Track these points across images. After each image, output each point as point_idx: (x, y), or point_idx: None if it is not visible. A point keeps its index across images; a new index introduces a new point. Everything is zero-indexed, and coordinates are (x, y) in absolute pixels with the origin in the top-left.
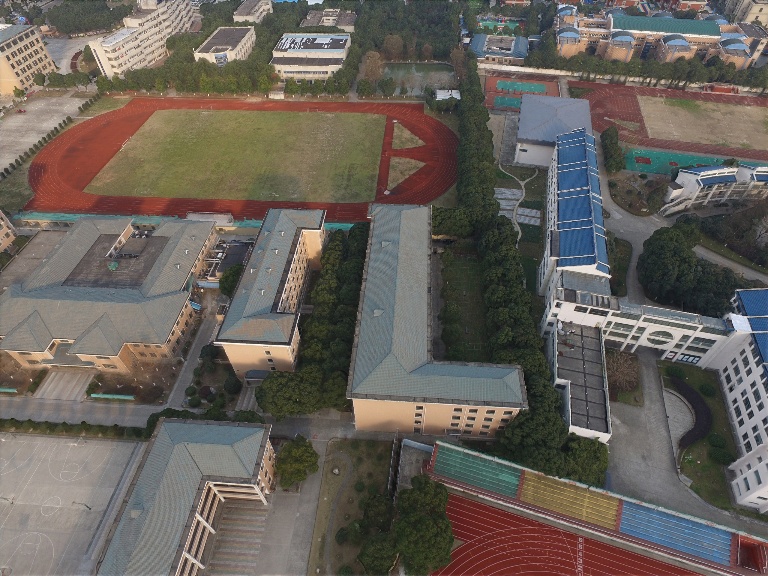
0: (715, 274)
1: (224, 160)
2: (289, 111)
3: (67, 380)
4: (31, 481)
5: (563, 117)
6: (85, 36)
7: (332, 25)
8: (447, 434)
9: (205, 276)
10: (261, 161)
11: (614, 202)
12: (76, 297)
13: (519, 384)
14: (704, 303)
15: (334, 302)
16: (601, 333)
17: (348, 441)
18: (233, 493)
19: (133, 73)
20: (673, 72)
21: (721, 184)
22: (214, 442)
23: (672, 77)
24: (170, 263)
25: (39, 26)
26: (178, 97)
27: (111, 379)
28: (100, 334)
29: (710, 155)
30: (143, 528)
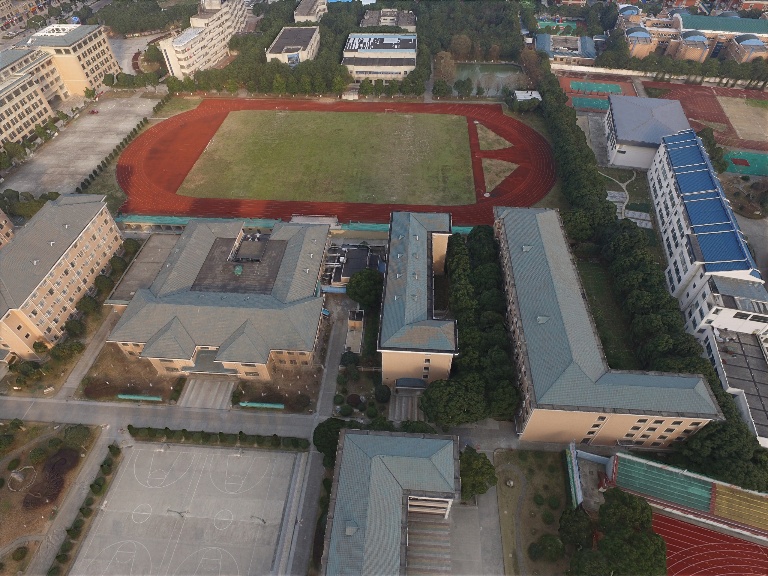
0: None
1: (312, 162)
2: (366, 112)
3: (208, 388)
4: (196, 493)
5: (660, 118)
6: (140, 36)
7: (391, 25)
8: (616, 445)
9: (326, 281)
10: (350, 163)
11: None
12: (214, 303)
13: (708, 394)
14: None
15: (476, 308)
16: (760, 340)
17: (514, 452)
18: (418, 507)
19: (203, 73)
20: (752, 72)
21: None
22: (410, 455)
23: (751, 77)
24: (299, 268)
25: None
26: (249, 98)
27: (259, 387)
28: (247, 341)
29: None
30: (365, 546)
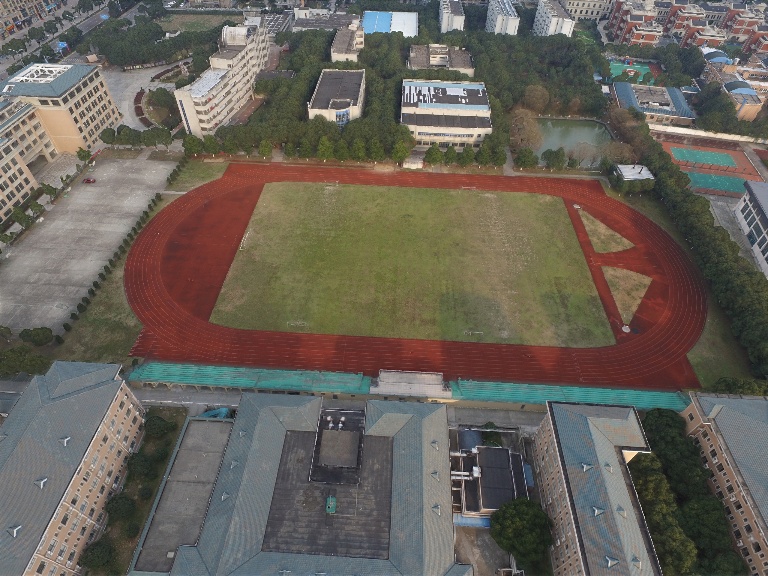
0: None
1: (385, 268)
2: (436, 188)
3: None
4: None
5: None
6: (141, 68)
7: None
8: None
9: None
10: (435, 271)
11: None
12: None
13: None
14: None
15: None
16: None
17: None
18: None
19: (228, 130)
20: None
21: None
22: None
23: None
24: (427, 507)
25: (84, 54)
26: (287, 163)
27: None
28: None
29: None
30: None
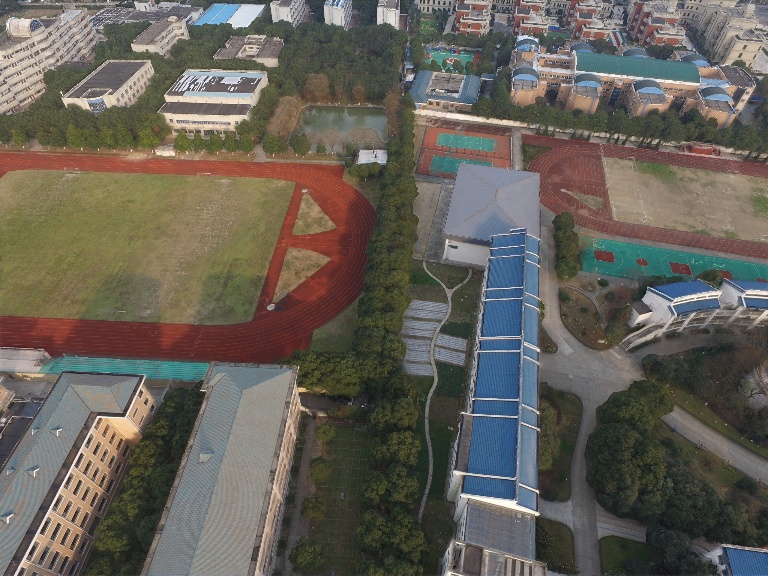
0: (692, 495)
1: (70, 251)
2: (176, 174)
3: None
4: None
5: (504, 202)
6: None
7: None
8: None
9: None
10: (118, 253)
11: (564, 326)
12: None
13: None
14: (675, 556)
15: (123, 550)
16: None
17: None
18: None
19: None
20: (644, 129)
21: (700, 310)
22: None
23: (643, 135)
24: None
25: None
26: (43, 151)
27: None
28: None
29: (687, 248)
30: None
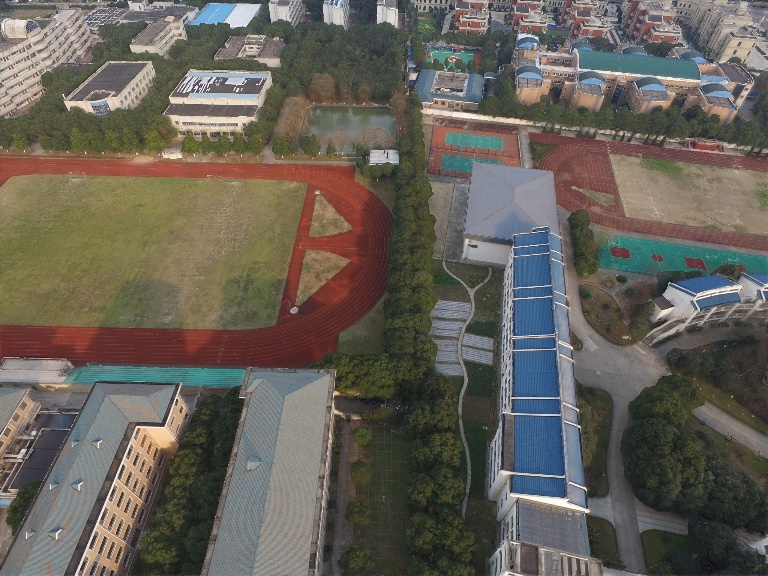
0: (733, 487)
1: (83, 258)
2: (185, 177)
3: None
4: None
5: (522, 201)
6: None
7: None
8: None
9: None
10: (133, 259)
11: (587, 322)
12: None
13: None
14: (723, 548)
15: (172, 562)
16: None
17: None
18: None
19: None
20: (650, 126)
21: (721, 304)
22: None
23: (649, 132)
24: None
25: None
26: (45, 156)
27: None
28: None
29: (699, 243)
30: None
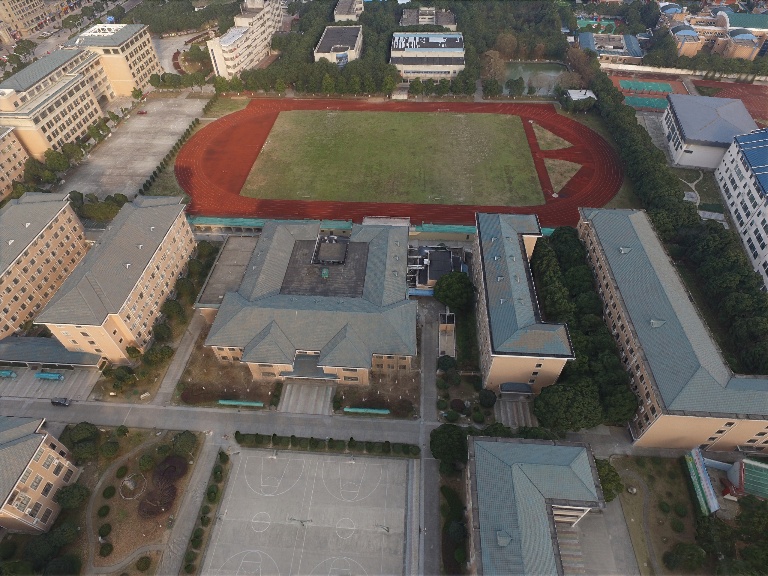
0: None
1: (372, 162)
2: (417, 112)
3: (306, 393)
4: (313, 501)
5: (726, 117)
6: (176, 36)
7: None
8: (734, 450)
9: (410, 283)
10: (411, 163)
11: None
12: (310, 306)
13: None
14: None
15: (575, 311)
16: None
17: (630, 458)
18: None
19: (250, 73)
20: None
21: None
22: (548, 463)
23: None
24: (388, 270)
25: None
26: (297, 98)
27: (362, 392)
28: (350, 345)
29: None
30: (523, 557)
